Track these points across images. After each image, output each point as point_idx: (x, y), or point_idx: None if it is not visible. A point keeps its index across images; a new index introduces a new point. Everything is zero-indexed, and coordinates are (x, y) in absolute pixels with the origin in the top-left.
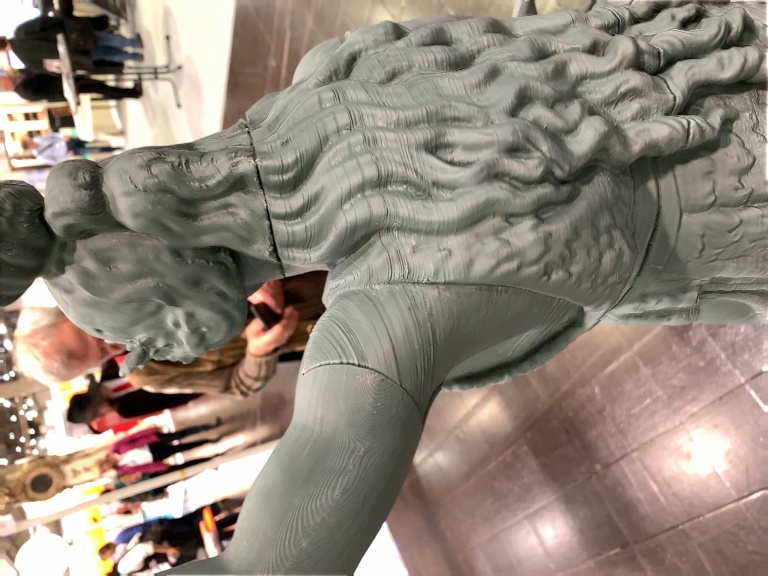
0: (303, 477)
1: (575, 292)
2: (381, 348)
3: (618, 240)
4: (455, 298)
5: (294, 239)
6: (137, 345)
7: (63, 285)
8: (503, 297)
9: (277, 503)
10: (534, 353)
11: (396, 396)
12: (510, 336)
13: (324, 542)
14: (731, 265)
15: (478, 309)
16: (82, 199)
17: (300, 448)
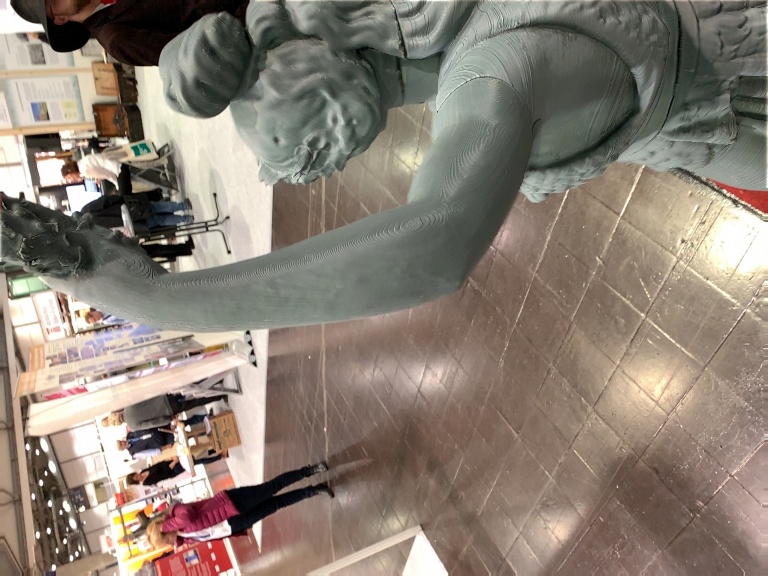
0: (454, 144)
1: (626, 39)
2: (494, 65)
3: (651, 12)
4: (539, 38)
5: (416, 28)
6: (303, 151)
7: (255, 94)
8: (574, 43)
9: (439, 161)
10: (606, 140)
11: (511, 93)
12: (584, 100)
13: (479, 176)
14: (750, 60)
15: (557, 49)
16: (275, 9)
17: (448, 135)
